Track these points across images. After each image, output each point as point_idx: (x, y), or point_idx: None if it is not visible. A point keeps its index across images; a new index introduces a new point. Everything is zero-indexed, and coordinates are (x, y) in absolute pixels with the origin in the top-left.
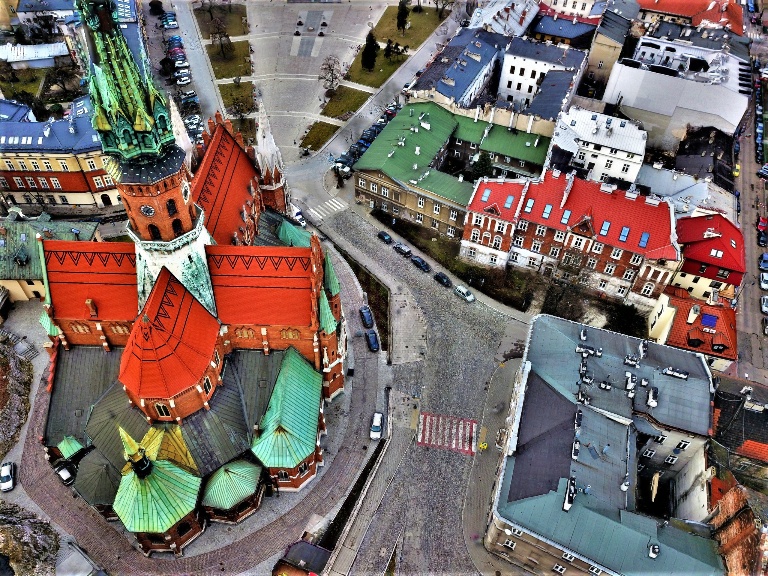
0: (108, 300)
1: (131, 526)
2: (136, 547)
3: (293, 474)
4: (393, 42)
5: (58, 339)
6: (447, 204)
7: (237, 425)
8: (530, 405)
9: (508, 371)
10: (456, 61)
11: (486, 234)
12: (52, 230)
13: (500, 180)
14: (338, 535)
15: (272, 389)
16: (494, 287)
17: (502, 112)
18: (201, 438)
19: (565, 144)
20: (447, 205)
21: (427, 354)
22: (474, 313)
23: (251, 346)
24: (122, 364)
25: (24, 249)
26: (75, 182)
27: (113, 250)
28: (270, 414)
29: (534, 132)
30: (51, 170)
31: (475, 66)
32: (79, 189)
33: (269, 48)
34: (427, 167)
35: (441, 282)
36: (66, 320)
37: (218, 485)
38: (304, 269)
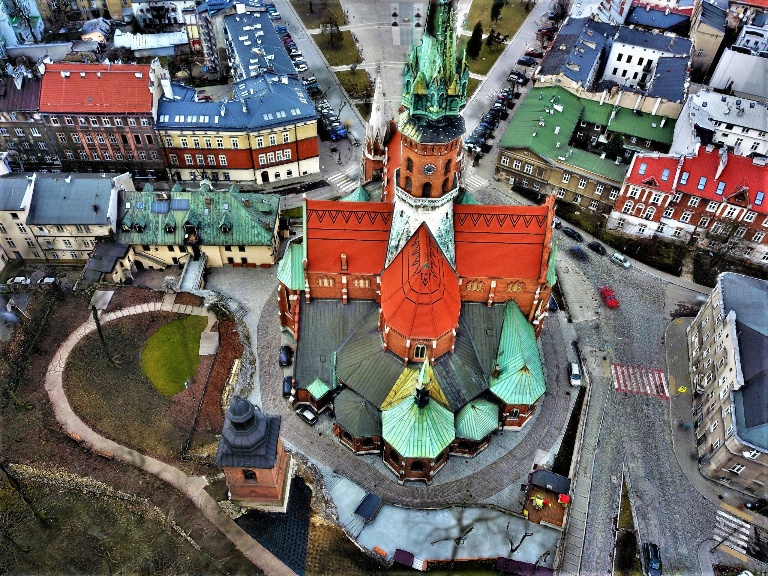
0: (358, 255)
1: (406, 452)
2: (388, 477)
3: (525, 412)
4: (495, 32)
5: (299, 293)
6: (595, 179)
7: (475, 368)
8: (744, 347)
9: (679, 328)
10: (575, 48)
11: (640, 205)
12: (249, 200)
13: (655, 155)
14: (565, 467)
15: (499, 337)
16: (646, 255)
17: (629, 95)
18: (449, 378)
19: (702, 123)
20: (595, 180)
21: (601, 313)
22: (633, 278)
23: (475, 299)
24: (386, 310)
25: (227, 217)
26: (241, 159)
27: (369, 209)
28: (506, 357)
29: (659, 114)
30: (222, 148)
31: (591, 53)
32: (243, 166)
33: (372, 38)
34: (567, 146)
35: (596, 250)
36: (316, 274)
37: (467, 419)
38: (539, 226)
